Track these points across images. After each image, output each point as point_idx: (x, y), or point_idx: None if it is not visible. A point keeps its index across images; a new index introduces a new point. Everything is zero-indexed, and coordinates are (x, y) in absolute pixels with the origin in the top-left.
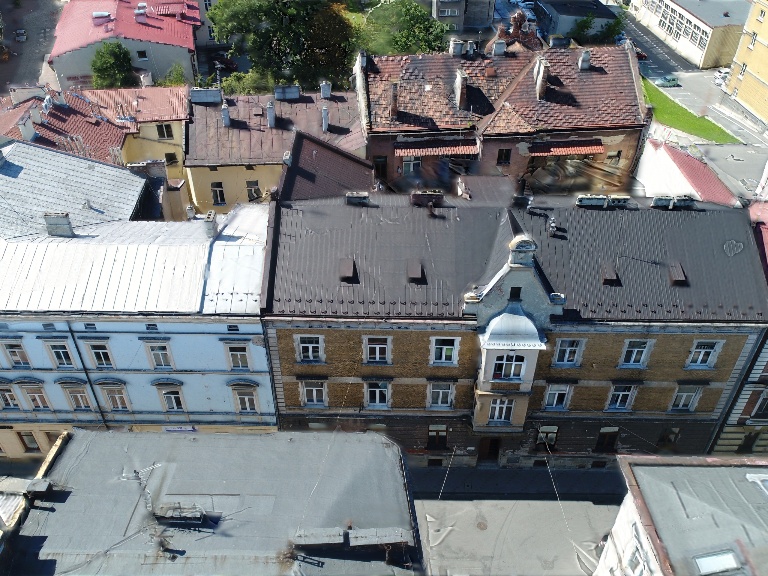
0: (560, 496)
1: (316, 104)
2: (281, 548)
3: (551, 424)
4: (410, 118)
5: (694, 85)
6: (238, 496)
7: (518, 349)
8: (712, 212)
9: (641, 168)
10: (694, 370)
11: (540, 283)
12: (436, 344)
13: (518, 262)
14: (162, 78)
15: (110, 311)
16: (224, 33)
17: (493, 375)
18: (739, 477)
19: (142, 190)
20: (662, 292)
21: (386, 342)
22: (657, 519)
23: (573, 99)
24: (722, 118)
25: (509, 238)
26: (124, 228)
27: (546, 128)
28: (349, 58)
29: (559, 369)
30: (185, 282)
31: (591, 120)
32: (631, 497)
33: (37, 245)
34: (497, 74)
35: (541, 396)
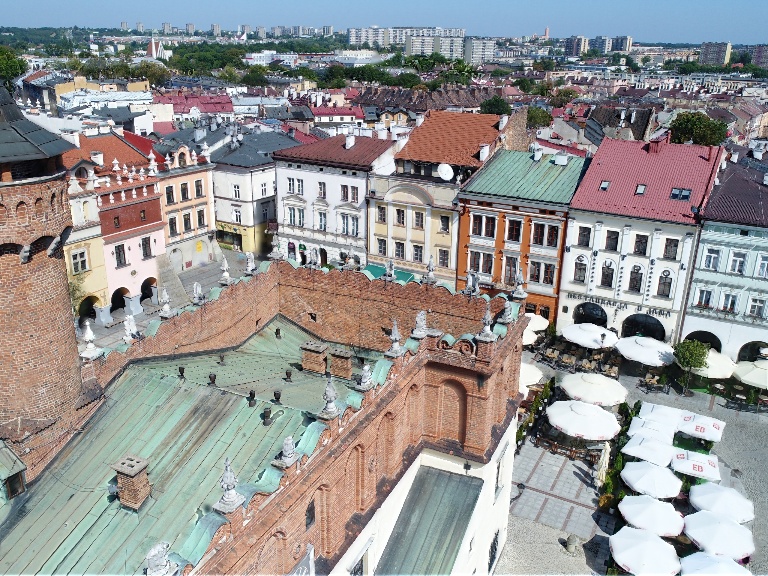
0: None
1: None
2: None
3: None
4: None
5: None
6: None
7: None
8: None
9: None
10: None
11: None
12: None
13: None
14: None
15: None
16: None
17: None
18: None
19: None
20: None
21: None
22: None
23: None
24: None
25: None
26: None
27: None
28: None
29: None
30: None
31: None
32: None
33: None
34: None
35: None
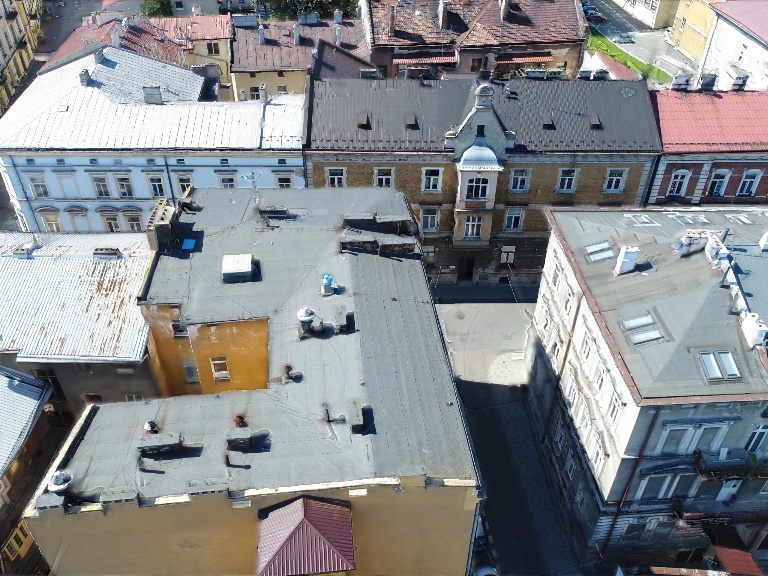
0: (518, 300)
1: (331, 28)
2: (336, 225)
3: (510, 244)
4: (404, 35)
5: (646, 42)
6: (306, 209)
7: (483, 171)
8: (621, 81)
9: None
10: (610, 194)
11: (497, 121)
12: (426, 175)
13: (482, 104)
14: None
15: (196, 148)
16: None
17: (467, 196)
18: (619, 215)
19: (203, 84)
20: (584, 133)
21: (391, 173)
22: (565, 233)
23: (529, 21)
24: (667, 65)
25: None
26: (196, 103)
27: (508, 42)
28: (352, 6)
29: (514, 194)
30: (248, 130)
31: (543, 36)
32: (553, 234)
33: (139, 107)
34: (471, 3)
35: (502, 219)
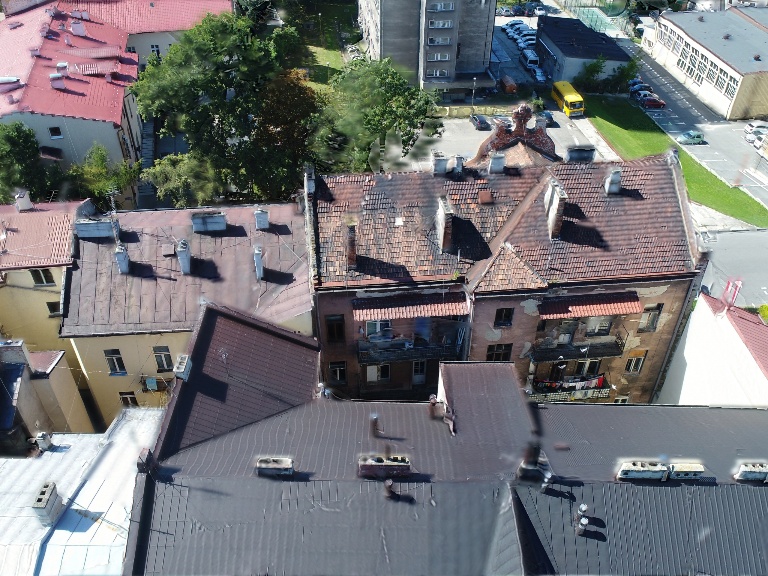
0: None
1: (249, 238)
2: None
3: None
4: (374, 266)
5: (722, 142)
6: None
7: None
8: None
9: (692, 332)
10: None
11: None
12: None
13: None
14: (80, 160)
15: None
16: (151, 111)
17: None
18: None
19: None
20: None
21: None
22: None
23: (598, 237)
24: (759, 189)
25: (514, 553)
26: None
27: (562, 281)
28: (310, 139)
29: None
30: None
31: (623, 268)
32: None
33: None
34: (494, 200)
35: None
